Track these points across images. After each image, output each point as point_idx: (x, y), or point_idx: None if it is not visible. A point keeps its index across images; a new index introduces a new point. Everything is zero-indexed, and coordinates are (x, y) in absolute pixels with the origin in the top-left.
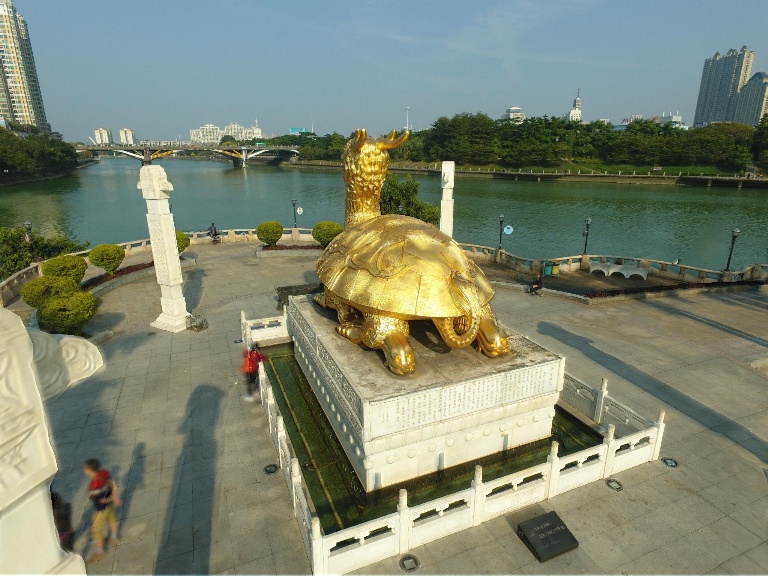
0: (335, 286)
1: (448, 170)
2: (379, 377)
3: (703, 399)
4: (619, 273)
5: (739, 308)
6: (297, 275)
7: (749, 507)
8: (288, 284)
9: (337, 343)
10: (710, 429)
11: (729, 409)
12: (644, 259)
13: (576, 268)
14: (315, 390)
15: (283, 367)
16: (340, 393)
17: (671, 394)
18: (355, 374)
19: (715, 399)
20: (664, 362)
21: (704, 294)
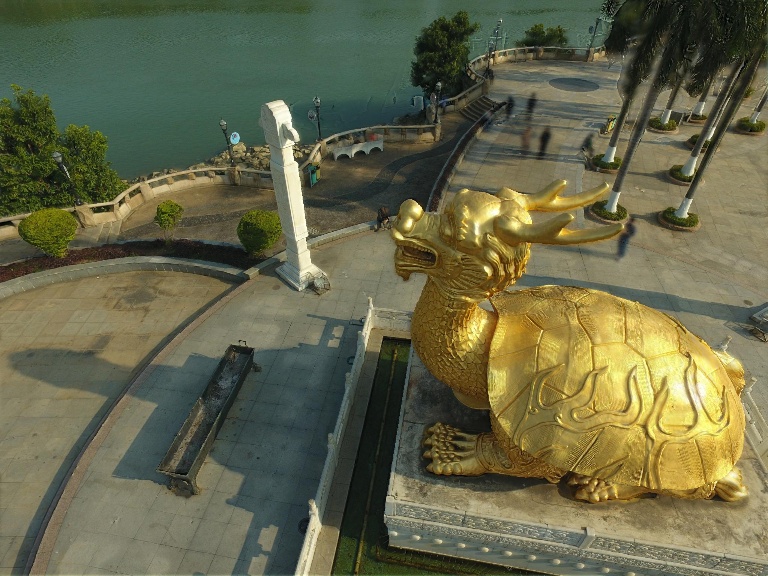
0: (666, 480)
1: (285, 119)
2: (741, 521)
3: (634, 285)
4: (360, 151)
5: (502, 167)
6: (14, 386)
7: (765, 362)
8: (42, 419)
9: (623, 520)
10: (675, 312)
11: (651, 284)
12: (368, 128)
13: (319, 159)
14: (525, 566)
15: (394, 575)
16: (712, 572)
17: (623, 293)
18: (731, 544)
19: (635, 280)
20: (572, 261)
21: (465, 160)
